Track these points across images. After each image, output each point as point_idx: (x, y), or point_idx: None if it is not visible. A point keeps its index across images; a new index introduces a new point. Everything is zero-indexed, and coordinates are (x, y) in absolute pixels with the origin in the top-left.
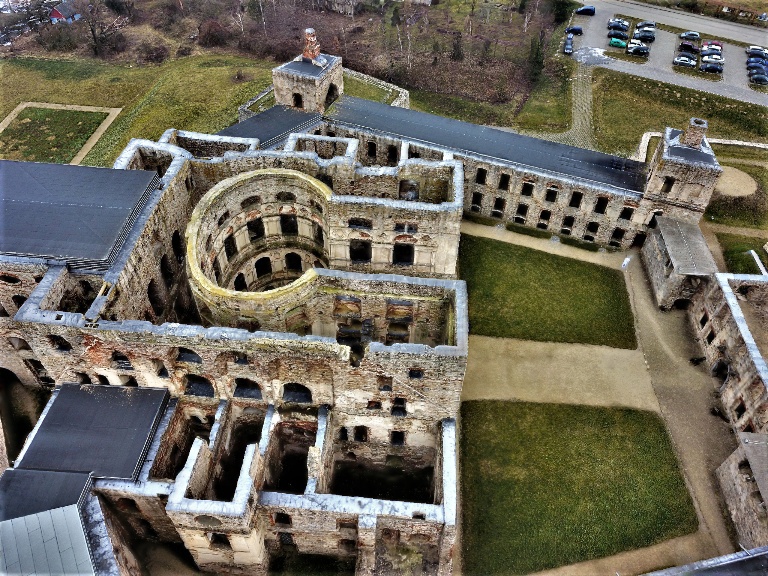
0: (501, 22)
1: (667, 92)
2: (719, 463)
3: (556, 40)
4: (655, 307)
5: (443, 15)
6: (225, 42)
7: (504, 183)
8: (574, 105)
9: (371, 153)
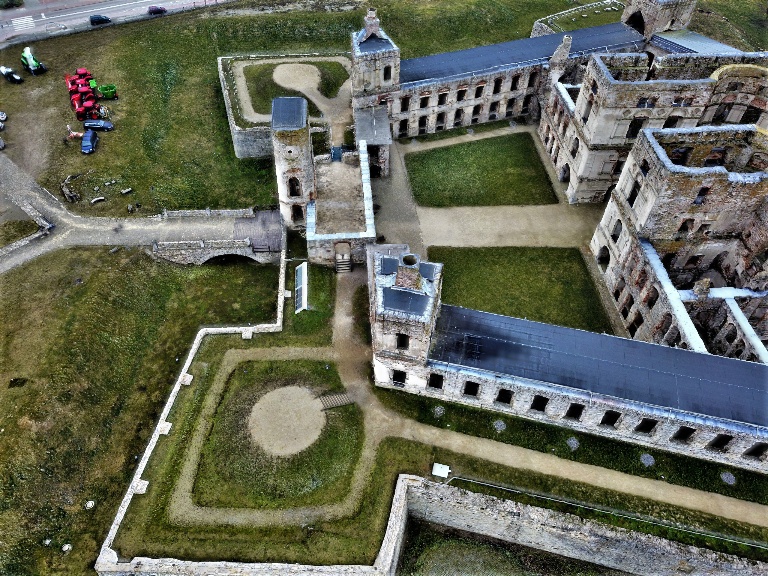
0: None
1: None
2: (383, 182)
3: None
4: None
5: None
6: None
7: None
8: None
9: None
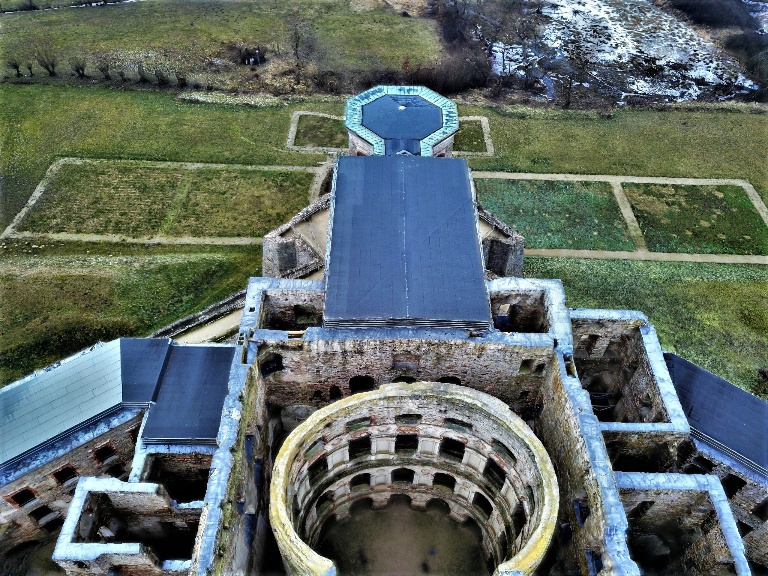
0: None
1: None
2: None
3: None
4: None
5: None
6: None
7: None
8: None
9: None
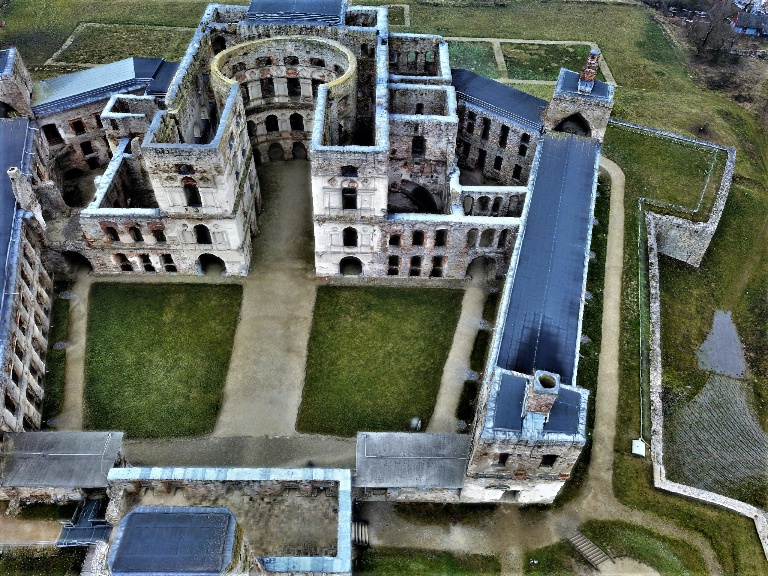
0: None
1: None
2: None
3: None
4: None
5: None
6: None
7: None
8: None
9: None
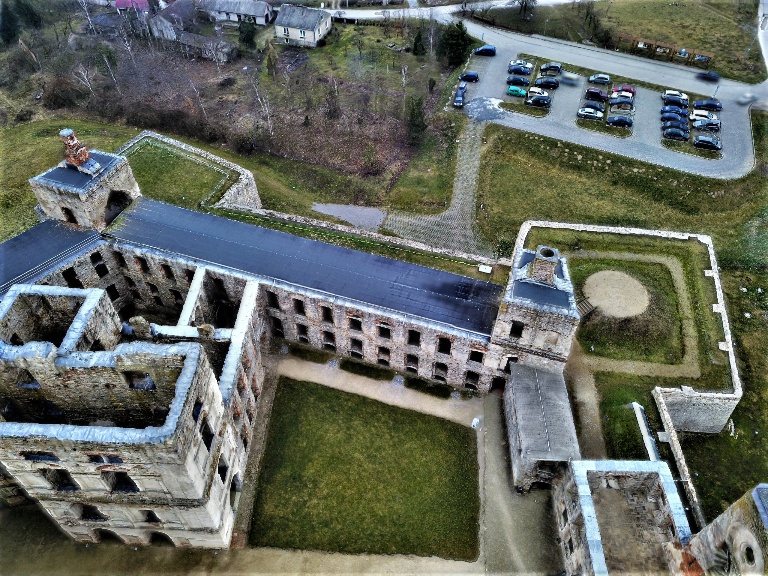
0: (392, 66)
1: (567, 154)
2: None
3: (448, 89)
4: (510, 487)
5: (327, 60)
6: (74, 102)
7: (328, 315)
8: (457, 175)
9: (171, 274)
